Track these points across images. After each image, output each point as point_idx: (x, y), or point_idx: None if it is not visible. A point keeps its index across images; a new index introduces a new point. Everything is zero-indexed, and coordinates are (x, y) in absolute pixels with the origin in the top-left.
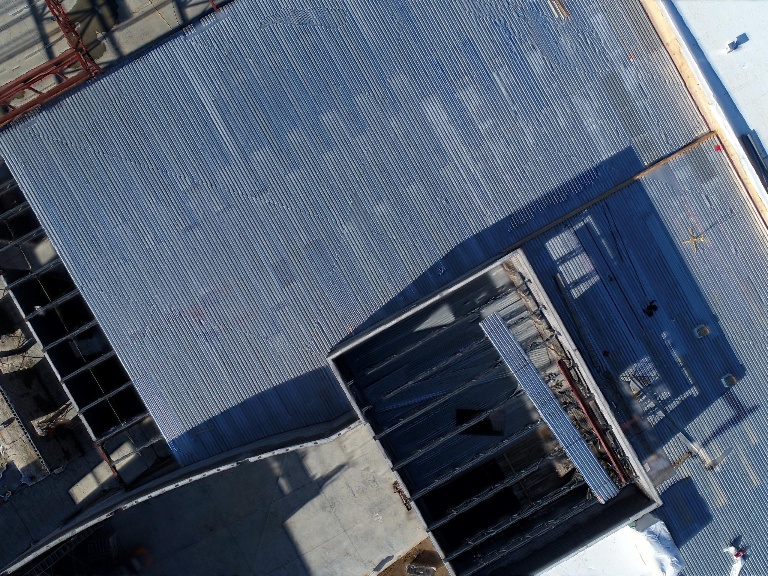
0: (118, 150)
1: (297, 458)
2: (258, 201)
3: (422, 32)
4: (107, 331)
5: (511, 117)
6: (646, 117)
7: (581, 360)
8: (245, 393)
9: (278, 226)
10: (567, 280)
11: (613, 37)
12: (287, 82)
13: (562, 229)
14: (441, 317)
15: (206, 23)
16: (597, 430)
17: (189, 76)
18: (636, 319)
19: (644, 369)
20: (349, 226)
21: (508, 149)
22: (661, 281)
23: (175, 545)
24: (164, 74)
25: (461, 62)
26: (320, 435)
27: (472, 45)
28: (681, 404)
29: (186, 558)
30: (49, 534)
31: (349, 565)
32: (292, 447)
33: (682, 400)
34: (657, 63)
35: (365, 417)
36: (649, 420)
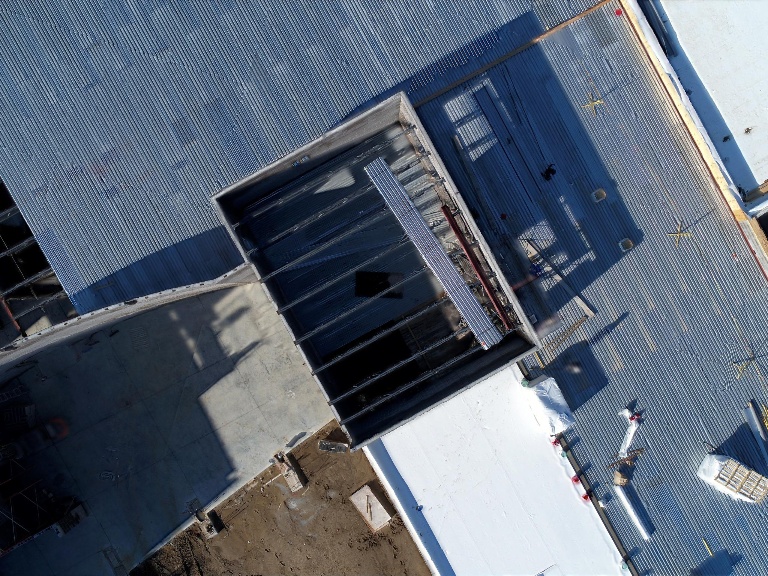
0: (21, 8)
1: (212, 334)
2: (159, 60)
3: None
4: (10, 187)
5: None
6: None
7: (463, 203)
8: (145, 250)
9: (179, 85)
10: (465, 142)
11: None
12: None
13: (461, 91)
14: (341, 180)
15: None
16: (480, 275)
17: None
18: (534, 182)
19: (541, 232)
20: (249, 86)
21: (409, 12)
22: (560, 145)
23: (92, 418)
24: None
25: None
26: None
27: None
28: (578, 268)
29: (102, 431)
30: None
31: (262, 440)
32: (179, 288)
33: (579, 264)
34: None
35: (249, 258)
36: (546, 283)
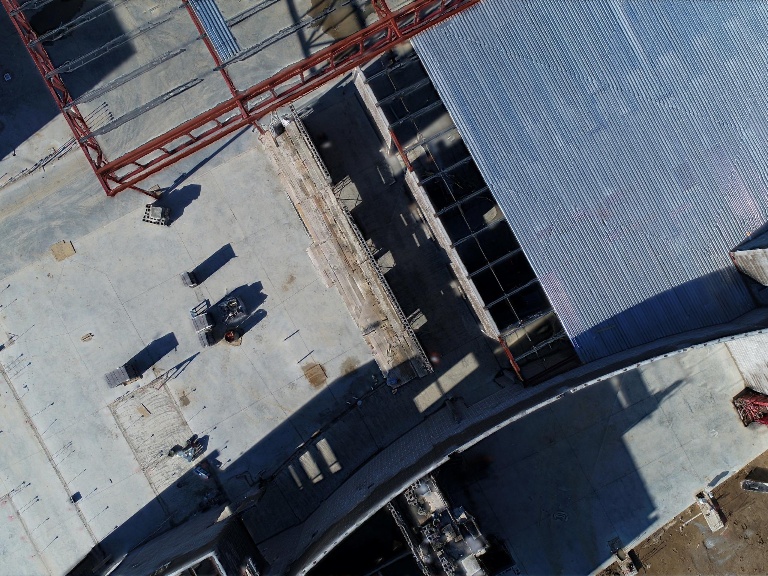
0: (529, 52)
1: (636, 373)
2: (662, 106)
3: None
4: (515, 229)
5: None
6: None
7: None
8: (645, 293)
9: (680, 131)
10: None
11: None
12: None
13: None
14: None
15: None
16: None
17: None
18: None
19: None
20: (748, 133)
21: None
22: None
23: (515, 455)
24: None
25: None
26: (753, 327)
27: None
28: None
29: (525, 468)
30: (425, 433)
31: (684, 479)
32: (737, 335)
33: None
34: None
35: None
36: None
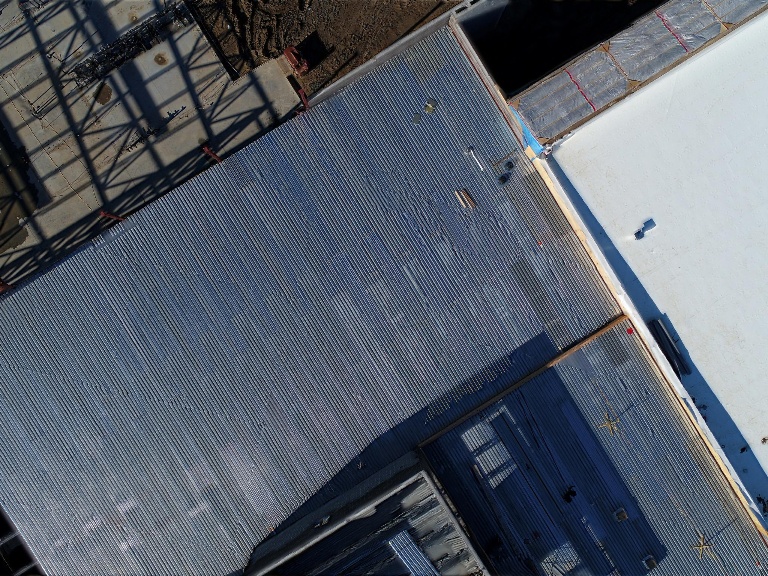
0: (33, 364)
1: None
2: (174, 407)
3: (331, 230)
4: (30, 543)
5: (423, 310)
6: (558, 302)
7: None
8: None
9: (195, 430)
10: (485, 470)
11: (522, 224)
12: (198, 287)
13: (478, 420)
14: None
15: (115, 233)
16: None
17: (100, 286)
18: (555, 505)
19: (565, 554)
20: (266, 426)
21: (421, 341)
22: (579, 466)
23: None
24: (75, 286)
25: (371, 257)
26: None
27: (381, 240)
28: None
29: None
30: None
31: None
32: None
33: None
34: (567, 248)
35: None
36: None
